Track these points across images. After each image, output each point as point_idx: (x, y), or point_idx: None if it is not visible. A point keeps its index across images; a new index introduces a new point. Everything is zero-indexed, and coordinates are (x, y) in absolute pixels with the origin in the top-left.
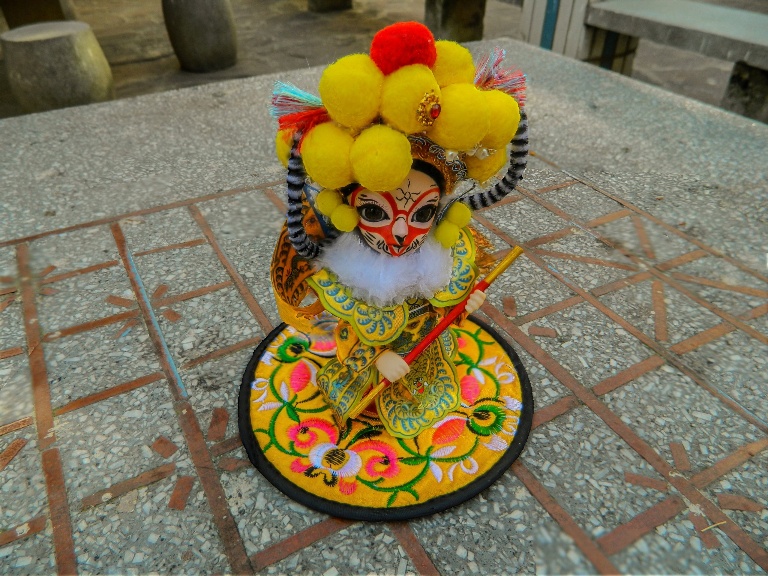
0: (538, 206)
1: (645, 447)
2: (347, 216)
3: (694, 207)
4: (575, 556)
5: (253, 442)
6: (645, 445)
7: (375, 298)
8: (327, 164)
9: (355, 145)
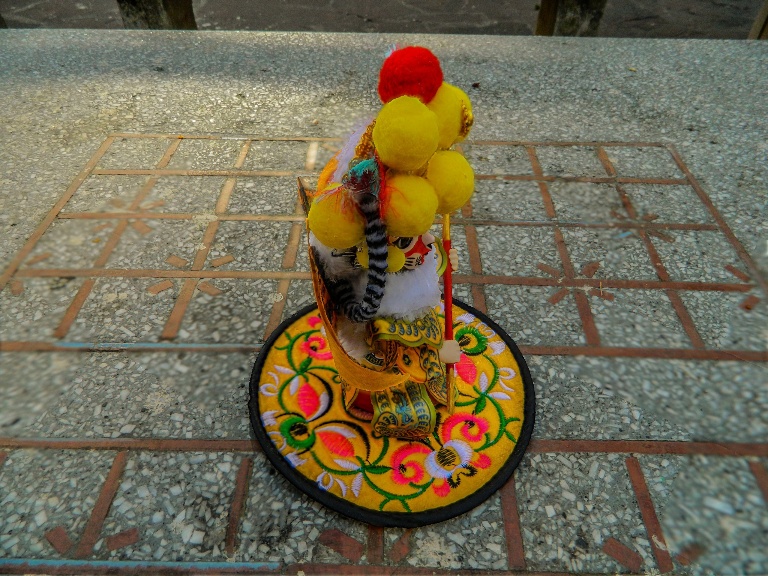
0: (256, 178)
1: (534, 279)
2: (402, 254)
3: (342, 116)
4: (594, 361)
5: (394, 516)
6: (533, 278)
7: (425, 309)
8: (432, 211)
9: (438, 181)
